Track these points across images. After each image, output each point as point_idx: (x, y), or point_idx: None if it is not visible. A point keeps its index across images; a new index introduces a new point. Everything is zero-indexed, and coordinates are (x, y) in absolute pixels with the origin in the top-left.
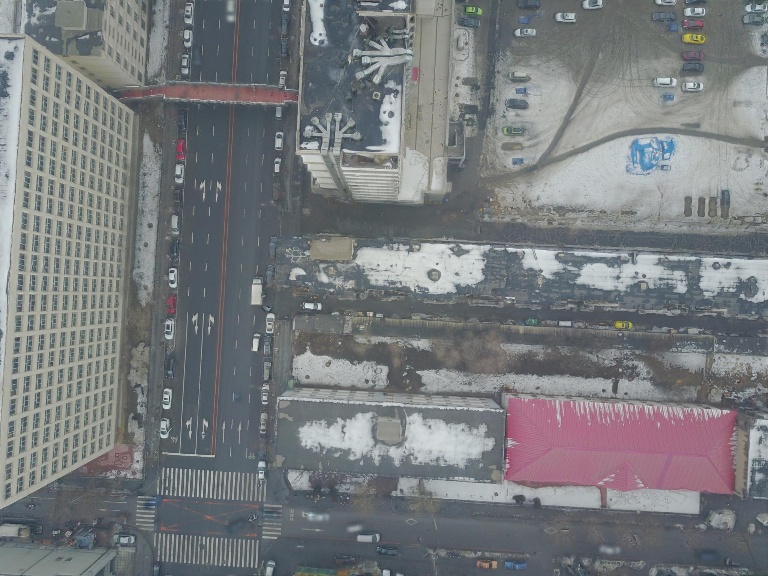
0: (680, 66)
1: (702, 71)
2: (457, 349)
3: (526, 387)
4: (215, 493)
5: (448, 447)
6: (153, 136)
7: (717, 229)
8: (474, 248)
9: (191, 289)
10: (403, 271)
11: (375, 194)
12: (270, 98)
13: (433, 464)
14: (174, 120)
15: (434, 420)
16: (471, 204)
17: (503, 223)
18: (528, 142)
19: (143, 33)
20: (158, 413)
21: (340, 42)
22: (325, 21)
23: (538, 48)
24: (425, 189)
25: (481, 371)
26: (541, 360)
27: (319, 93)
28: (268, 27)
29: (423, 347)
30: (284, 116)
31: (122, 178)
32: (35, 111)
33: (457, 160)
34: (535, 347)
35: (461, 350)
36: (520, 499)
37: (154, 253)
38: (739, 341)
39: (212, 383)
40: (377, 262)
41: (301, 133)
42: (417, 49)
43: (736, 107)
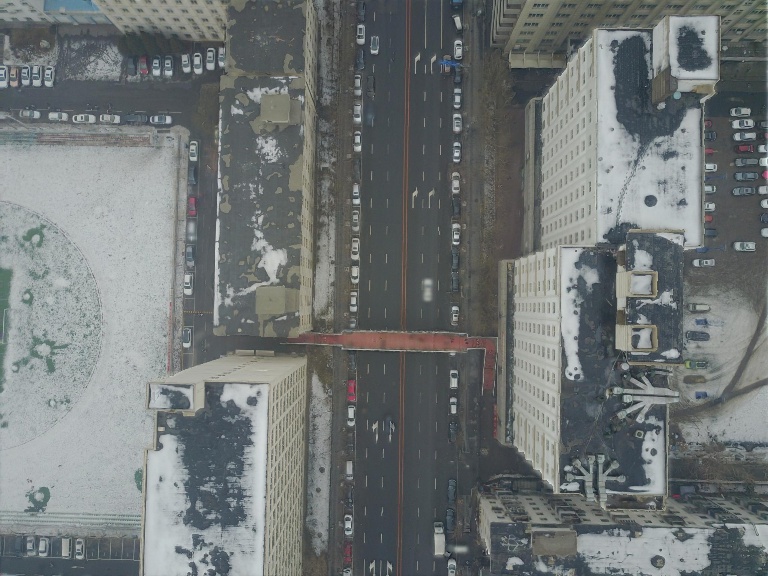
0: None
1: None
2: None
3: None
4: None
5: None
6: (322, 377)
7: None
8: (698, 532)
9: (367, 535)
10: (625, 558)
11: None
12: (450, 345)
13: None
14: (343, 360)
15: None
16: None
17: (689, 459)
18: (711, 375)
19: None
20: None
21: (597, 376)
22: (580, 354)
23: (717, 277)
24: None
25: None
26: None
27: (577, 430)
28: (437, 260)
29: None
30: None
31: (302, 434)
32: (273, 449)
33: None
34: None
35: None
36: None
37: (328, 500)
38: None
39: None
40: (598, 549)
41: (561, 474)
42: None
43: None
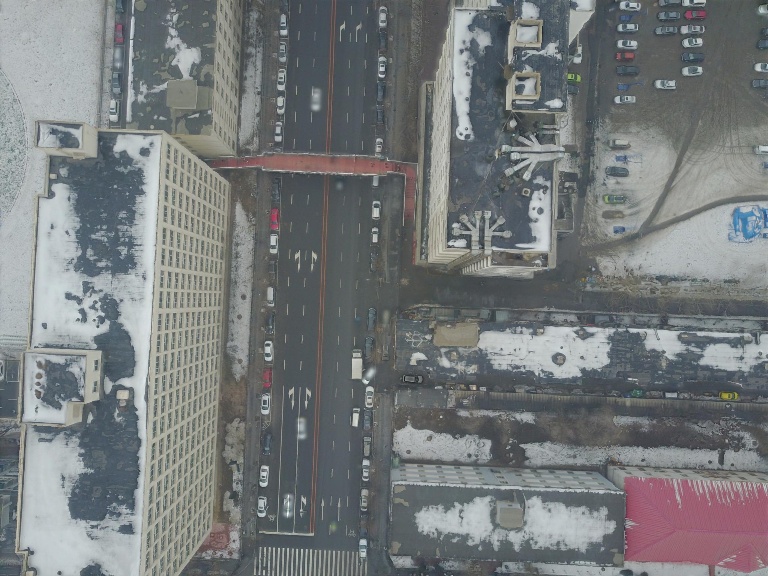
0: None
1: None
2: (570, 427)
3: (631, 459)
4: (314, 572)
5: (568, 531)
6: (246, 205)
7: None
8: (599, 331)
9: (287, 362)
10: (527, 355)
11: (492, 274)
12: (371, 169)
13: (553, 548)
14: (267, 189)
15: (553, 503)
16: (573, 273)
17: (605, 292)
18: (629, 210)
19: (236, 101)
20: (254, 491)
21: (487, 137)
22: (471, 115)
23: (637, 115)
24: None
25: (585, 443)
26: (646, 431)
27: (466, 189)
28: (363, 94)
29: (526, 420)
30: (380, 184)
31: (220, 252)
32: (168, 207)
33: (564, 232)
34: (640, 418)
35: (575, 428)
36: (628, 574)
37: (249, 326)
38: None
39: (310, 459)
40: (500, 346)
41: (448, 230)
42: None
43: None
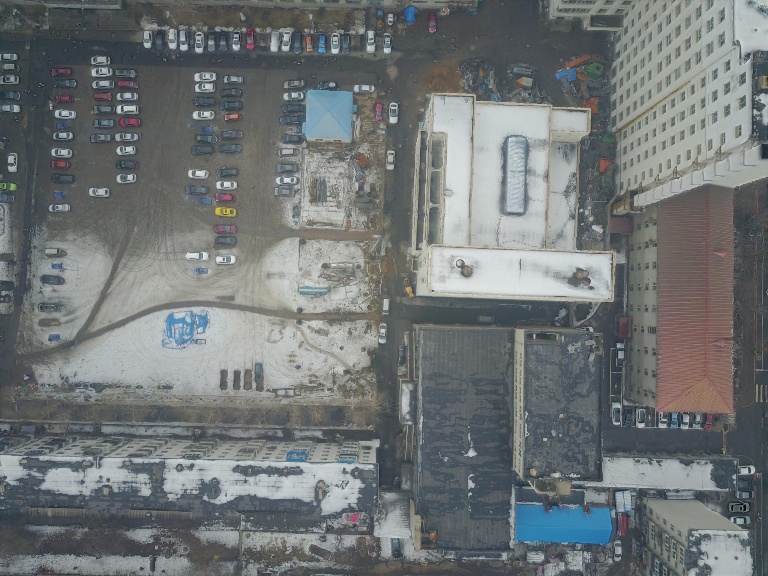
0: (214, 239)
1: (235, 244)
2: None
3: (64, 567)
4: None
5: None
6: None
7: (252, 402)
8: None
9: None
10: None
11: None
12: None
13: None
14: None
15: None
16: (8, 382)
17: (40, 401)
18: (65, 318)
19: None
20: None
21: None
22: None
23: (74, 222)
24: None
25: (19, 552)
26: (79, 539)
27: None
28: None
29: None
30: None
31: None
32: None
33: None
34: (72, 526)
35: None
36: None
37: None
38: (266, 518)
39: None
40: None
41: None
42: None
43: (270, 279)
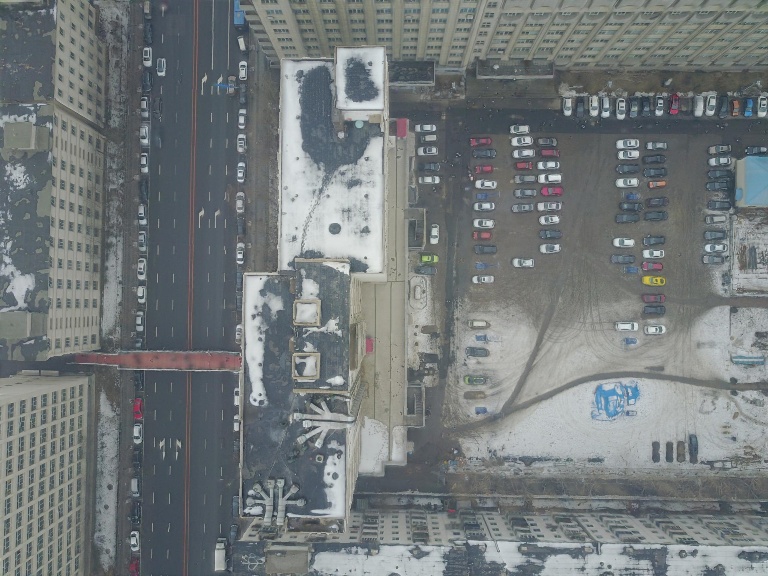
0: (641, 308)
1: (664, 313)
2: None
3: None
4: None
5: None
6: (110, 395)
7: (686, 474)
8: (434, 549)
9: (154, 551)
10: (362, 575)
11: None
12: (226, 364)
13: None
14: (131, 378)
15: None
16: (435, 456)
17: (469, 474)
18: (491, 390)
19: (96, 293)
20: None
21: (281, 402)
22: (264, 380)
23: (497, 293)
24: (386, 459)
25: None
26: None
27: (261, 455)
28: (223, 279)
29: None
30: None
31: (78, 454)
32: None
33: None
34: None
35: None
36: None
37: (115, 517)
38: None
39: None
40: (335, 567)
41: (244, 498)
42: (372, 316)
43: (700, 348)
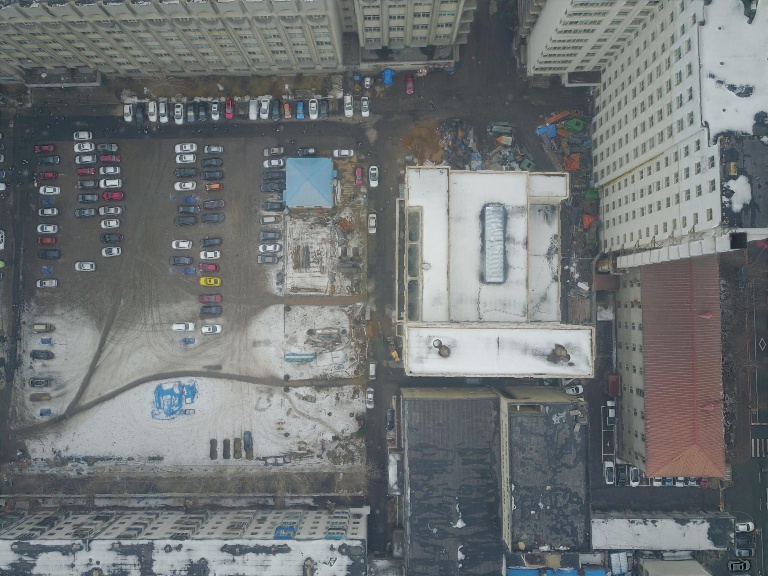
0: (199, 309)
1: (220, 313)
2: None
3: None
4: None
5: None
6: None
7: (243, 471)
8: None
9: None
10: None
11: None
12: None
13: None
14: None
15: None
16: (2, 457)
17: (34, 475)
18: (55, 392)
19: None
20: None
21: None
22: None
23: (62, 297)
24: None
25: None
26: None
27: None
28: None
29: None
30: None
31: None
32: None
33: None
34: None
35: None
36: None
37: None
38: None
39: None
40: None
41: None
42: None
43: (256, 347)
